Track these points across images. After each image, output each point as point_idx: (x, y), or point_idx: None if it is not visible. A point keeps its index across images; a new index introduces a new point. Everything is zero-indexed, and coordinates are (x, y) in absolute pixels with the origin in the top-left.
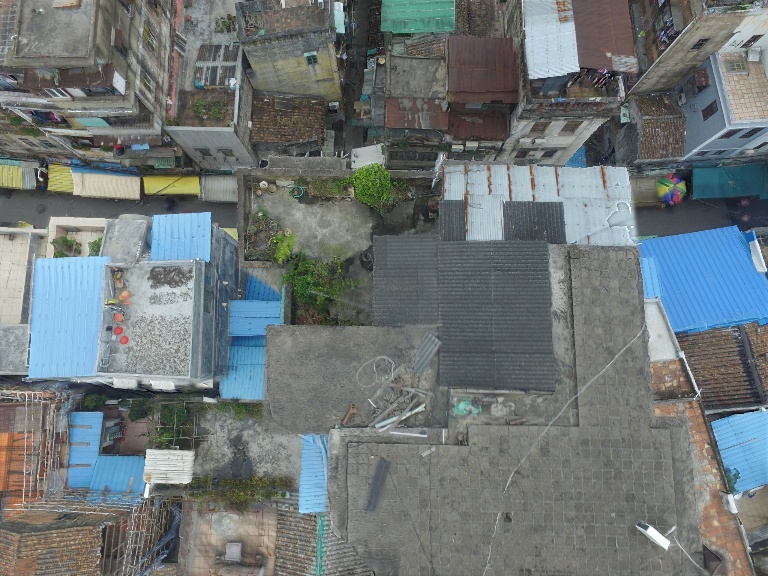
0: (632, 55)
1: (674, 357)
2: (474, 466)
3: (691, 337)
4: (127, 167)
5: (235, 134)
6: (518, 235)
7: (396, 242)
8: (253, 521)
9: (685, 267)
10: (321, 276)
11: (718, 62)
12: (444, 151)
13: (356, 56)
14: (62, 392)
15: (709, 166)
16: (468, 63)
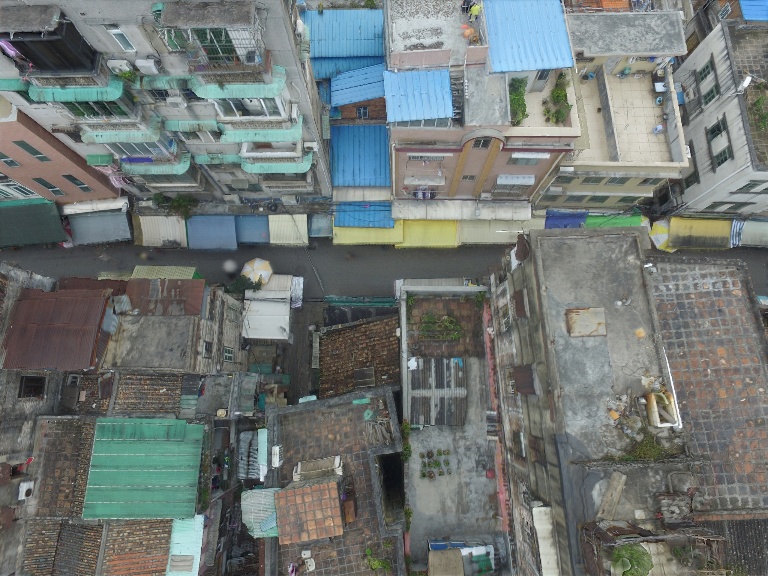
0: None
1: None
2: None
3: None
4: None
5: None
6: None
7: None
8: None
9: None
10: None
11: None
12: None
13: None
14: None
15: None
16: (72, 333)
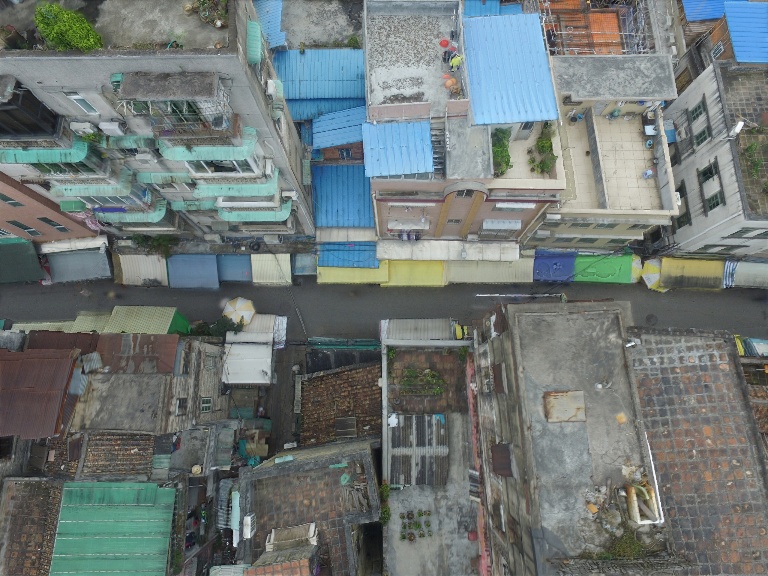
0: None
1: None
2: None
3: None
4: None
5: None
6: None
7: None
8: None
9: None
10: None
11: None
12: None
13: None
14: None
15: None
16: (37, 397)
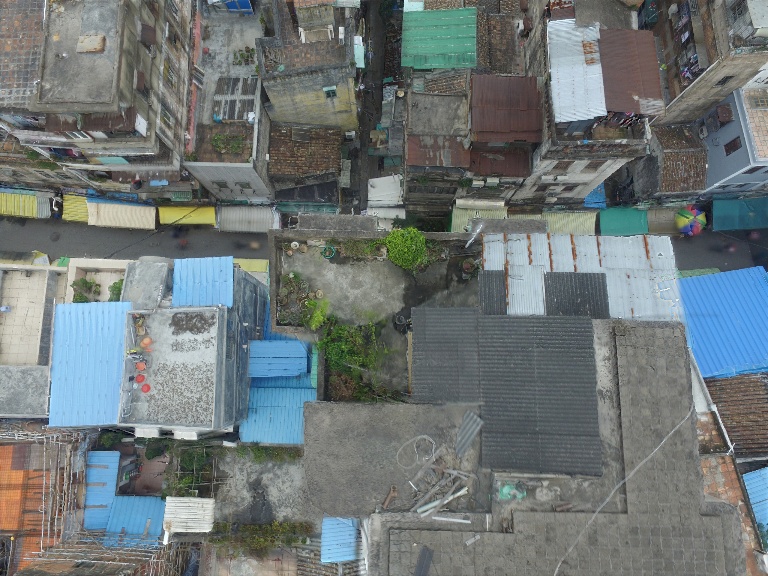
0: (659, 98)
1: (706, 410)
2: (520, 555)
3: (719, 382)
4: (144, 200)
5: (254, 169)
6: (560, 308)
7: (435, 315)
8: (272, 566)
9: (711, 309)
10: (355, 343)
11: (742, 98)
12: (464, 186)
13: None
14: (79, 432)
15: (730, 198)
16: (491, 102)
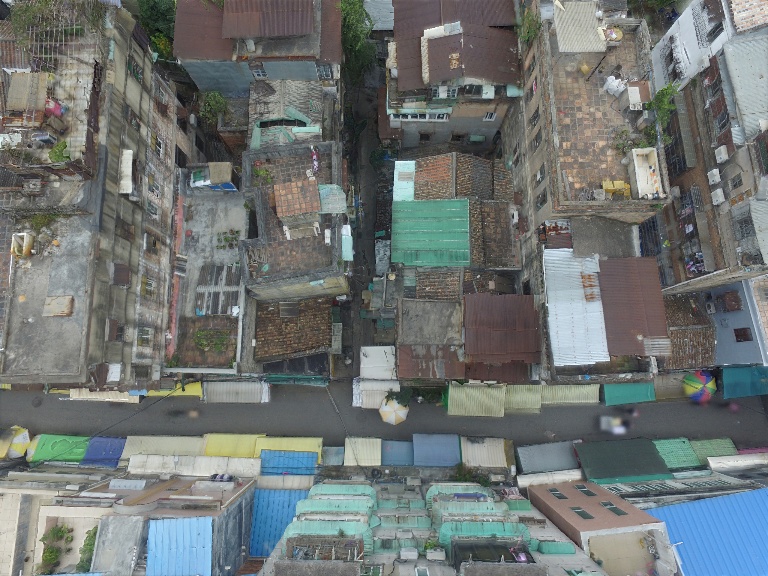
0: (665, 335)
1: None
2: None
3: None
4: None
5: None
6: None
7: None
8: None
9: (728, 542)
10: None
11: (751, 290)
12: (460, 383)
13: (363, 226)
14: None
15: (741, 367)
16: (486, 323)
